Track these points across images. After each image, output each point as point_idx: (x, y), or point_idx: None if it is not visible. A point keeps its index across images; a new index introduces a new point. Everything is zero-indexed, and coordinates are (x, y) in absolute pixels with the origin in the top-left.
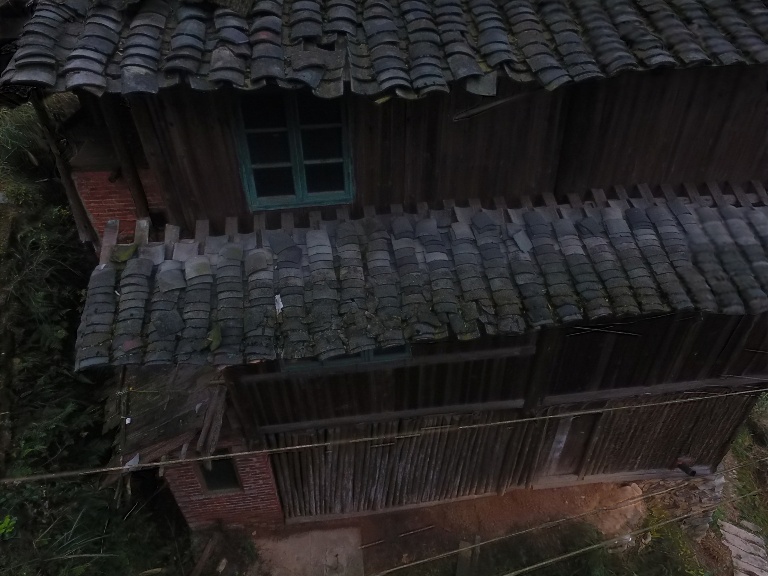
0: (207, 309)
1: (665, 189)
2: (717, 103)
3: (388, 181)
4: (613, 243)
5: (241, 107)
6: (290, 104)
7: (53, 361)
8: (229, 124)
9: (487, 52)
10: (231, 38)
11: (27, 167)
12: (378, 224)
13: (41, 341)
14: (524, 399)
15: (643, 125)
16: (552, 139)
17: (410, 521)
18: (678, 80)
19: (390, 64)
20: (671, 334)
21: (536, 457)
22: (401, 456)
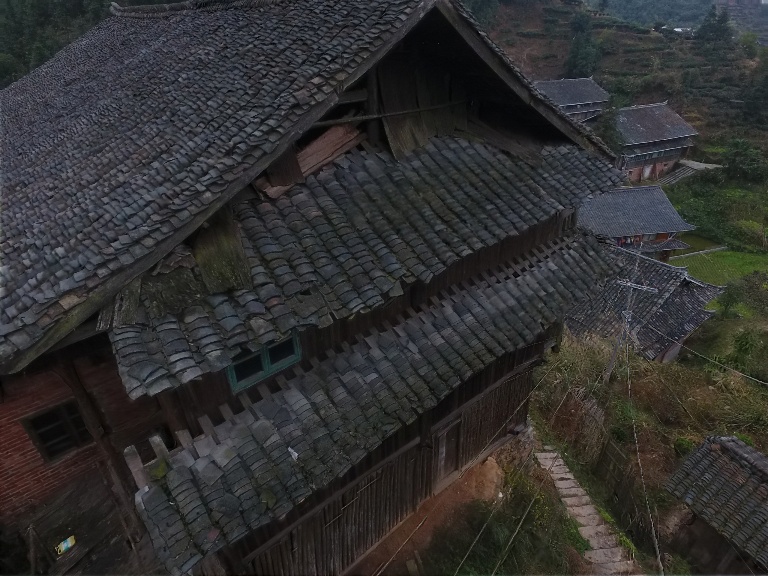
0: (248, 482)
1: (464, 284)
2: None
3: (321, 337)
4: (455, 329)
5: None
6: None
7: None
8: None
9: (391, 271)
10: (260, 311)
11: None
12: (327, 369)
13: None
14: (419, 436)
15: None
16: None
17: (365, 570)
18: None
19: (351, 297)
20: None
21: (432, 471)
22: (347, 522)
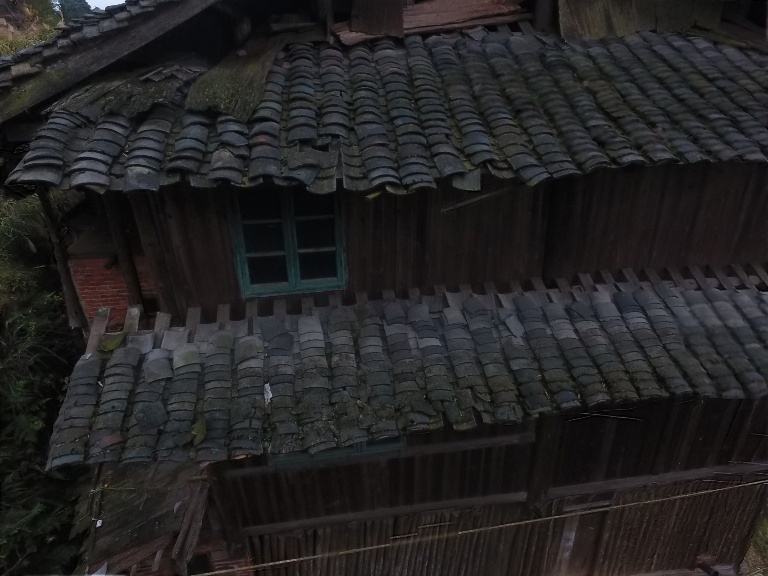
0: (193, 400)
1: (649, 273)
2: (688, 194)
3: (380, 268)
4: (604, 327)
5: (238, 201)
6: (285, 198)
7: (25, 456)
8: (226, 216)
9: (470, 152)
10: (231, 141)
11: (25, 254)
12: (370, 310)
13: (15, 434)
14: (527, 491)
15: (622, 214)
16: (537, 227)
17: None
18: (650, 174)
19: (380, 163)
20: (673, 418)
21: (544, 558)
22: (397, 559)
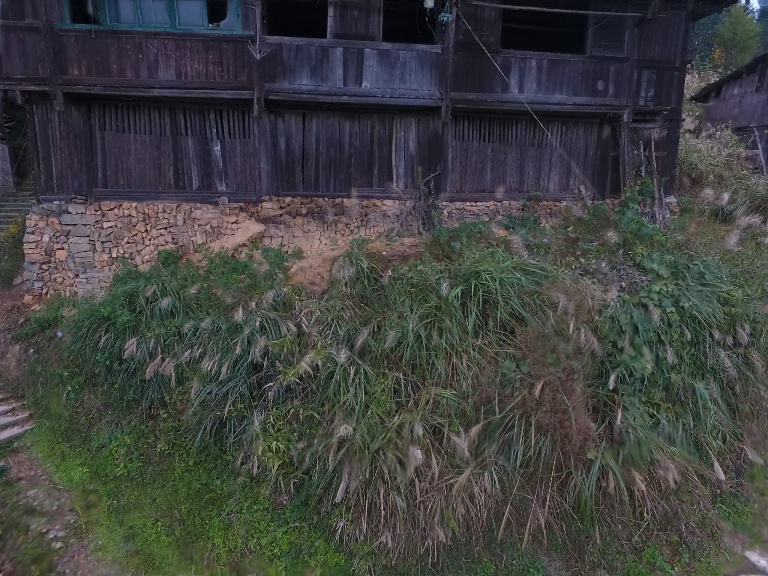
0: None
1: None
2: None
3: None
4: None
5: None
6: None
7: None
8: None
9: None
10: None
11: None
12: None
13: None
14: None
15: None
16: None
17: None
18: None
19: None
20: None
21: None
22: None
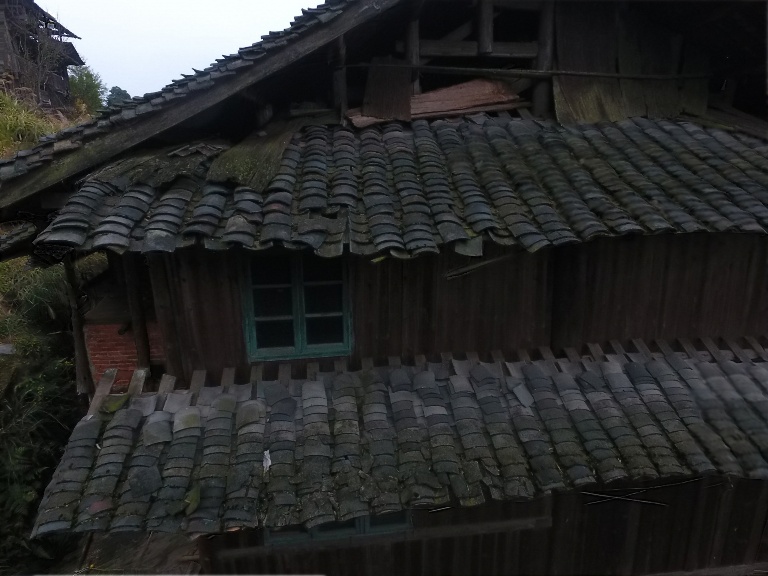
0: (190, 466)
1: (661, 344)
2: (693, 266)
3: (386, 334)
4: (617, 398)
5: (250, 266)
6: (296, 263)
7: (13, 529)
8: (238, 280)
9: (472, 221)
10: (246, 208)
11: (44, 320)
12: (375, 376)
13: (6, 504)
14: None
15: (627, 284)
16: (542, 296)
17: None
18: (652, 246)
19: (385, 230)
20: (702, 504)
21: None
22: None
